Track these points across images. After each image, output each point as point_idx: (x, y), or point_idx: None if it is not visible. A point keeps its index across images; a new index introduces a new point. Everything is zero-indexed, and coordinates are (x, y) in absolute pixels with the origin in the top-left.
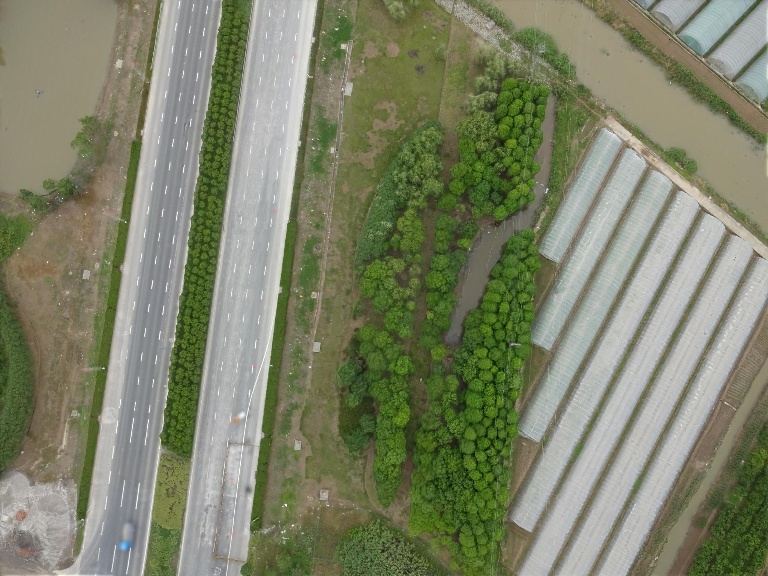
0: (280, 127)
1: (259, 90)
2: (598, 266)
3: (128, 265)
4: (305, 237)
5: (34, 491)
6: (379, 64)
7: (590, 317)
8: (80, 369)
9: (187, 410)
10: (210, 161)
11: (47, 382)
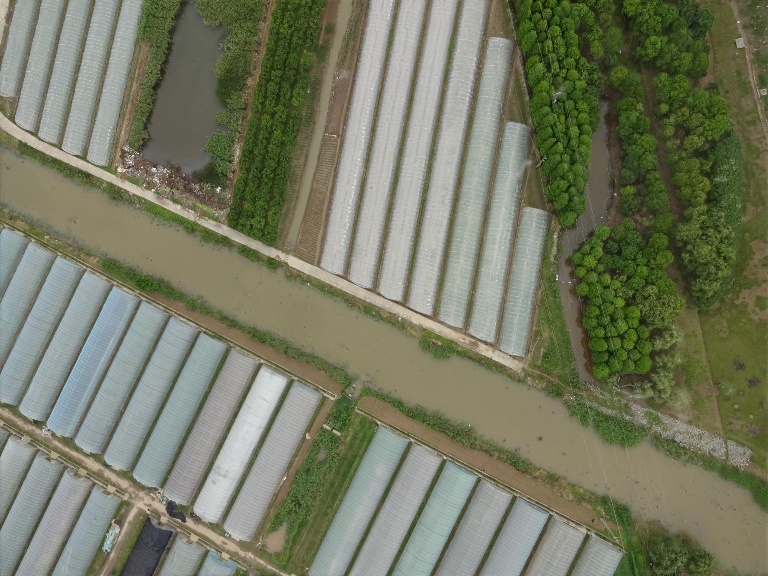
0: None
1: None
2: (485, 219)
3: None
4: None
5: None
6: None
7: (478, 168)
8: None
9: None
10: None
11: None
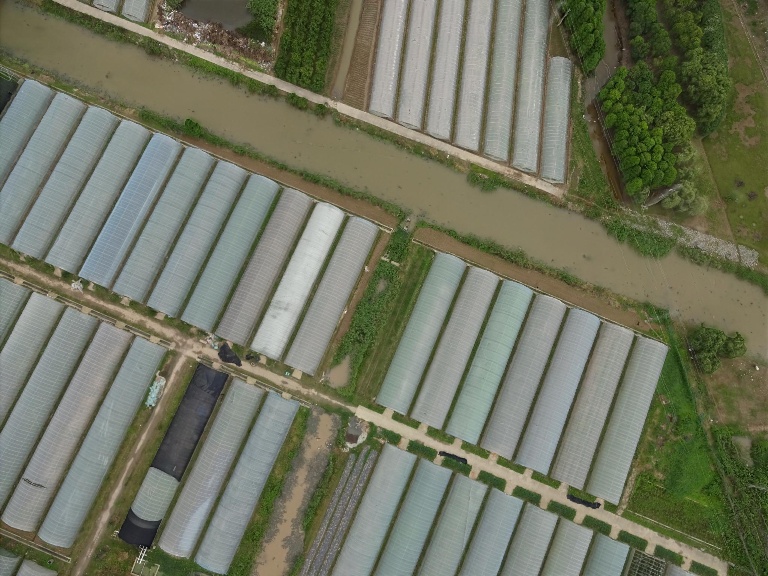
0: None
1: None
2: (518, 68)
3: None
4: (760, 10)
5: None
6: None
7: (508, 26)
8: None
9: None
10: None
11: None
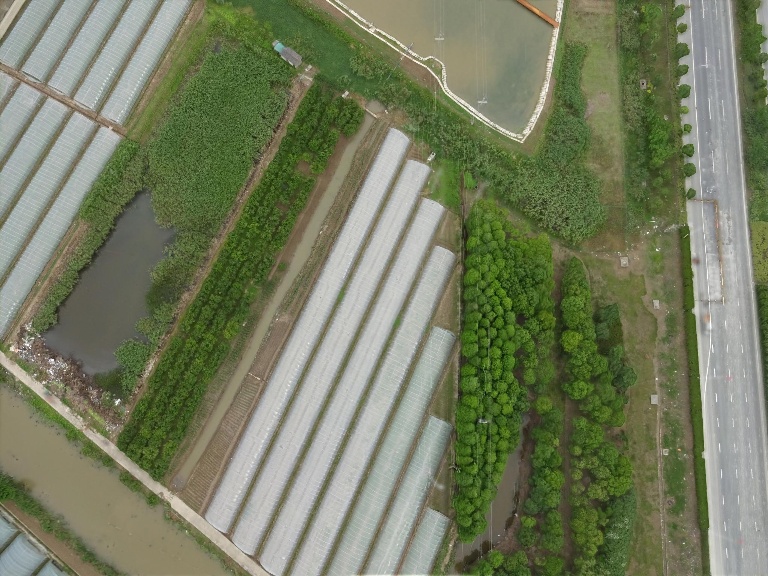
0: None
1: None
2: (387, 508)
3: None
4: (687, 514)
5: None
6: None
7: (393, 454)
8: None
9: None
10: None
11: None
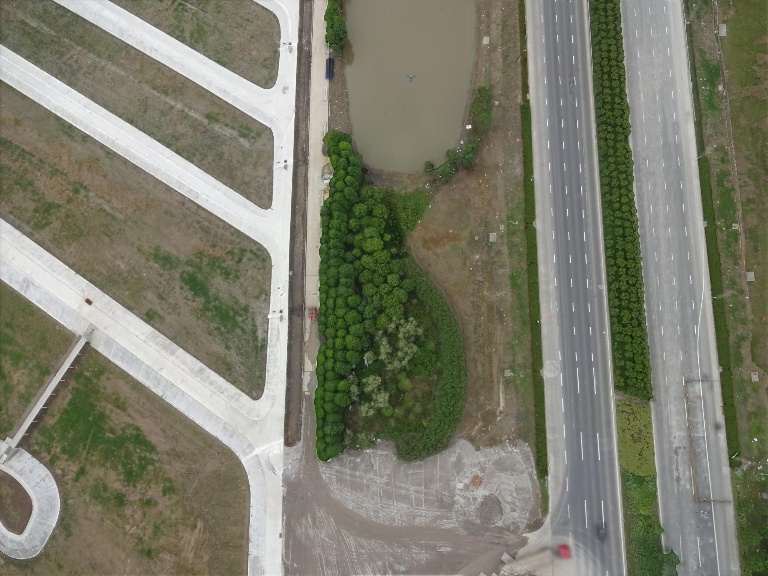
0: (667, 72)
1: (638, 42)
2: None
3: (540, 221)
4: (714, 171)
5: (484, 455)
6: (748, 3)
7: None
8: (504, 329)
9: (643, 350)
10: (610, 110)
11: (473, 346)
